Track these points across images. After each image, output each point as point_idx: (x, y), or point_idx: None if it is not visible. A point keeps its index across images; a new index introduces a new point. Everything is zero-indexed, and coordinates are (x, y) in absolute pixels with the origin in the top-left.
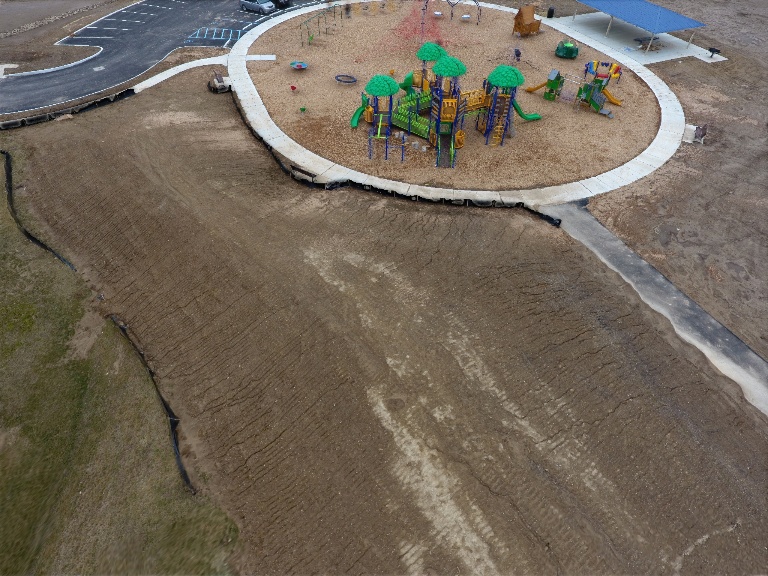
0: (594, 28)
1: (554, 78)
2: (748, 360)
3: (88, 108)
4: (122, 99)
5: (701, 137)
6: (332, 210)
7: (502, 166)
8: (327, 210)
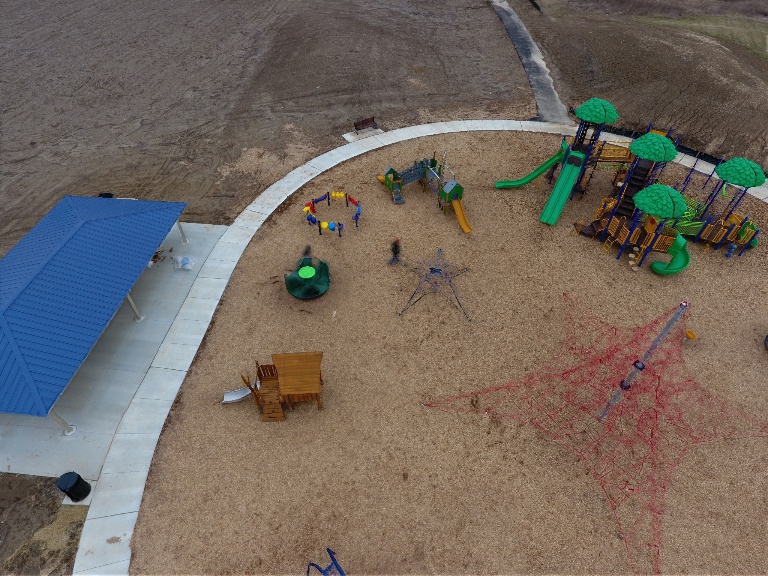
0: (94, 365)
1: None
2: (529, 61)
3: None
4: None
5: None
6: (760, 135)
7: None
8: (765, 136)
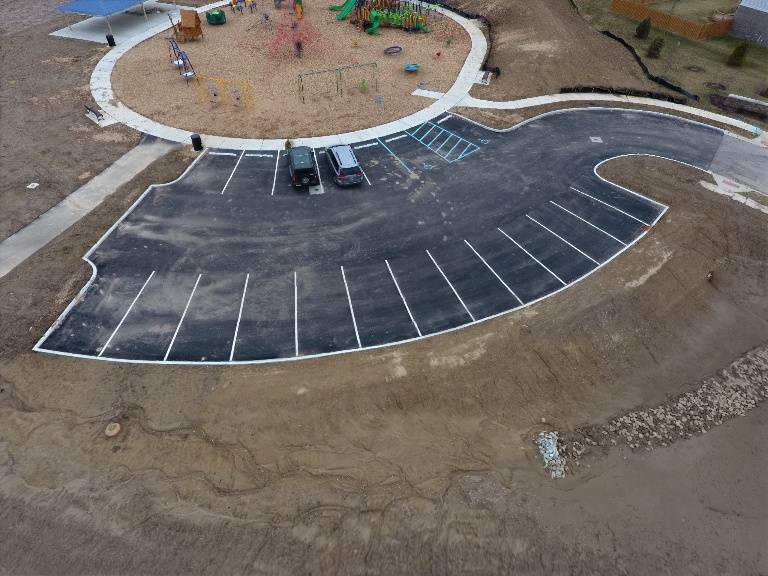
0: (127, 28)
1: None
2: None
3: (600, 91)
4: (572, 92)
5: None
6: None
7: None
8: (490, 1)
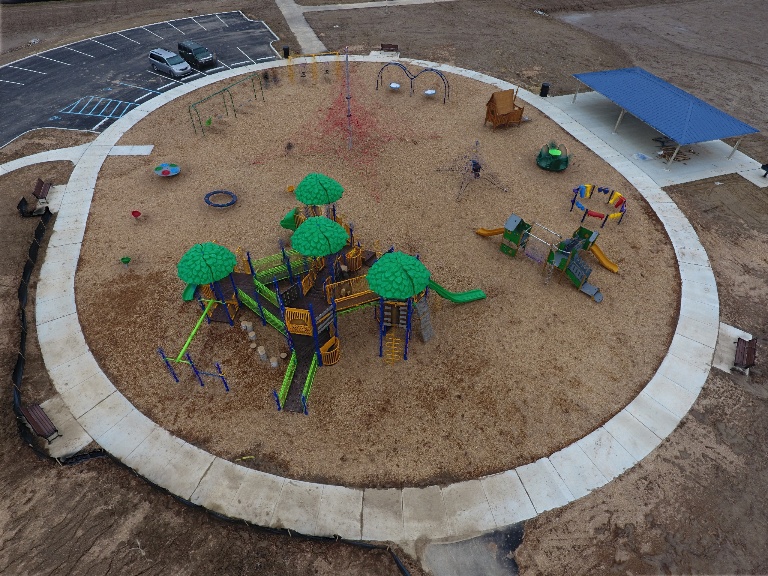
0: (600, 116)
1: (513, 228)
2: None
3: None
4: None
5: (745, 367)
6: None
7: (391, 415)
8: None
